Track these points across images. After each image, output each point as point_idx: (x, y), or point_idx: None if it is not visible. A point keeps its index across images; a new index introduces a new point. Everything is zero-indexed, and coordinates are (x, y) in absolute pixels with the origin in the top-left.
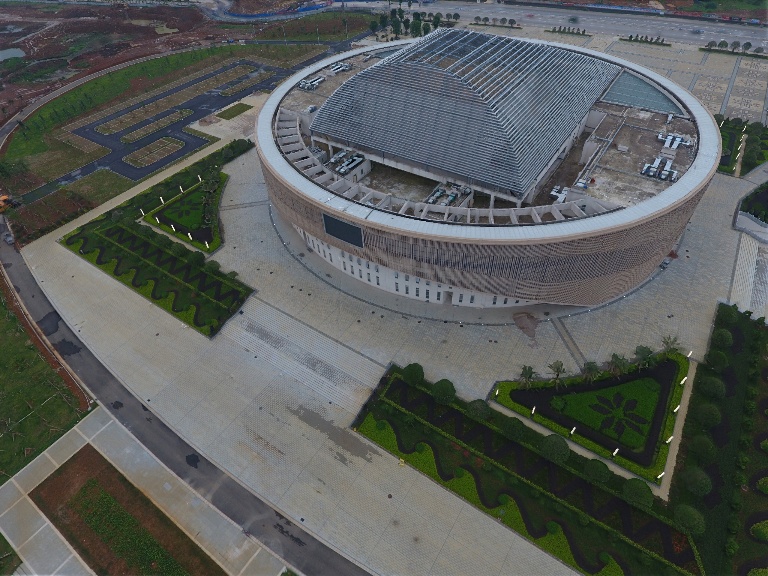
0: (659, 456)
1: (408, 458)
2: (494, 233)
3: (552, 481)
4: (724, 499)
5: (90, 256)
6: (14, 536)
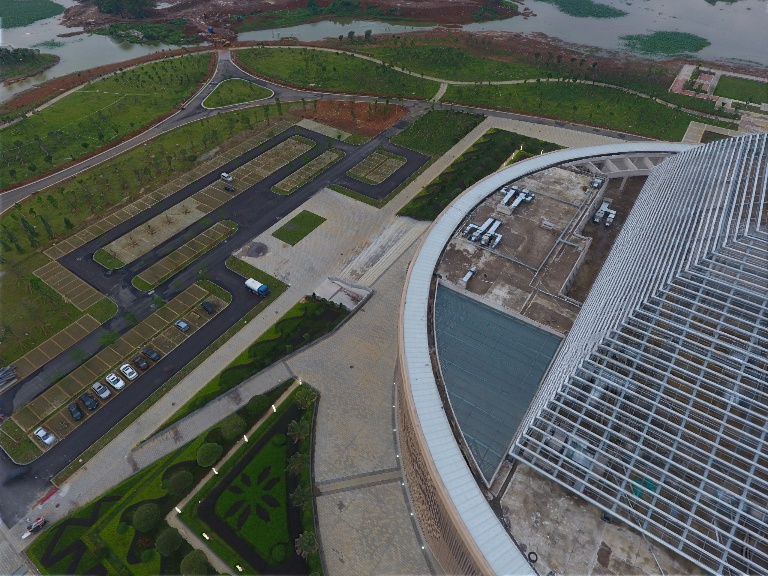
0: (517, 158)
1: None
2: (664, 147)
3: None
4: (489, 152)
5: None
6: None
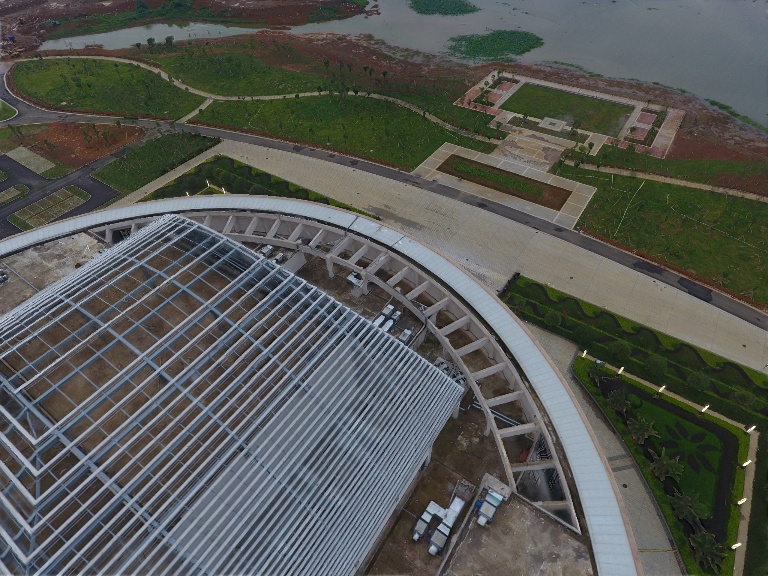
0: None
1: (346, 206)
2: (237, 202)
3: (266, 193)
4: None
5: (761, 377)
6: (562, 179)
